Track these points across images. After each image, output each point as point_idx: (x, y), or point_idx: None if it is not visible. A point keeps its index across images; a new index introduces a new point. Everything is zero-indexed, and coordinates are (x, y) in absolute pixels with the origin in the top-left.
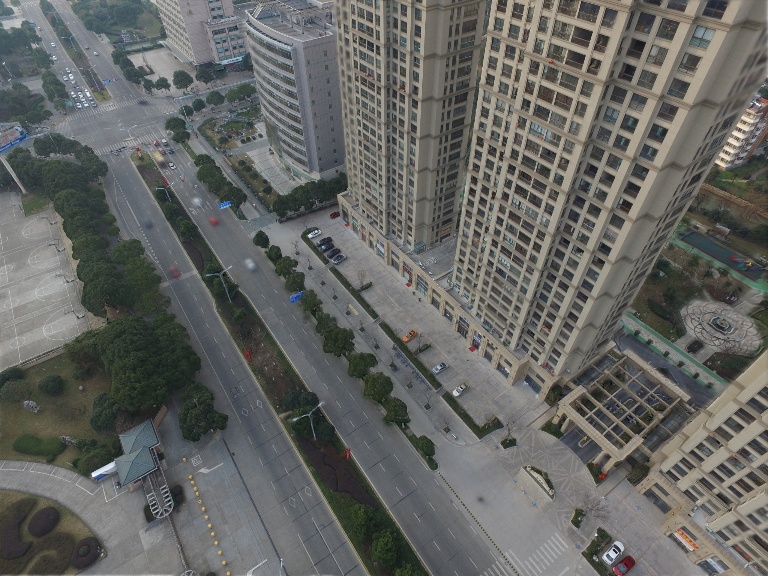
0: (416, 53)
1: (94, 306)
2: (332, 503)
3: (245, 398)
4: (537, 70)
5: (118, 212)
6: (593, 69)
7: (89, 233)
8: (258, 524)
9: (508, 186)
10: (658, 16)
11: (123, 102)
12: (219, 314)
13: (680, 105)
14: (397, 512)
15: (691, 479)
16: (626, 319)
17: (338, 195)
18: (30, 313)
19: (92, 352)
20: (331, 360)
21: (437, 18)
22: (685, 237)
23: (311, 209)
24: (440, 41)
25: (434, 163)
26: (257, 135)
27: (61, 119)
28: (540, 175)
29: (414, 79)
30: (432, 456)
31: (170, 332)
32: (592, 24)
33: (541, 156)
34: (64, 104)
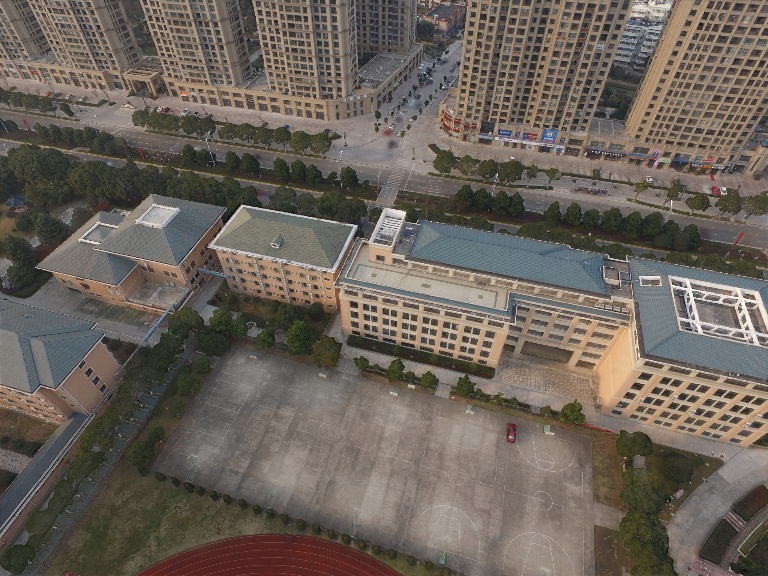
0: None
1: None
2: (28, 142)
3: None
4: None
5: None
6: None
7: None
8: None
9: None
10: None
11: None
12: None
13: None
14: None
15: None
16: None
17: None
18: None
19: None
20: (4, 115)
21: None
22: None
23: None
24: None
25: None
26: None
27: None
28: None
29: None
30: (74, 115)
31: None
32: None
33: None
34: None
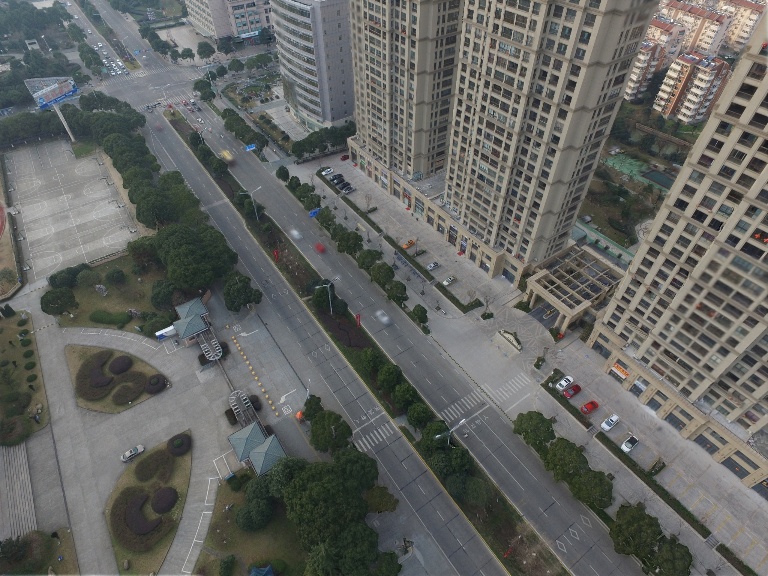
0: None
1: (147, 218)
2: (346, 354)
3: (274, 287)
4: None
5: (156, 156)
6: None
7: (137, 166)
8: (288, 368)
9: (485, 99)
10: None
11: (152, 70)
12: (249, 230)
13: (597, 13)
14: (397, 360)
15: (623, 321)
16: (589, 232)
17: (348, 138)
18: (90, 229)
19: (150, 249)
20: (343, 262)
21: None
22: (645, 174)
23: (324, 153)
24: None
25: (429, 97)
26: (274, 97)
27: (98, 84)
28: (507, 85)
29: (413, 22)
30: (425, 323)
31: (212, 235)
32: None
33: (508, 69)
34: (100, 70)
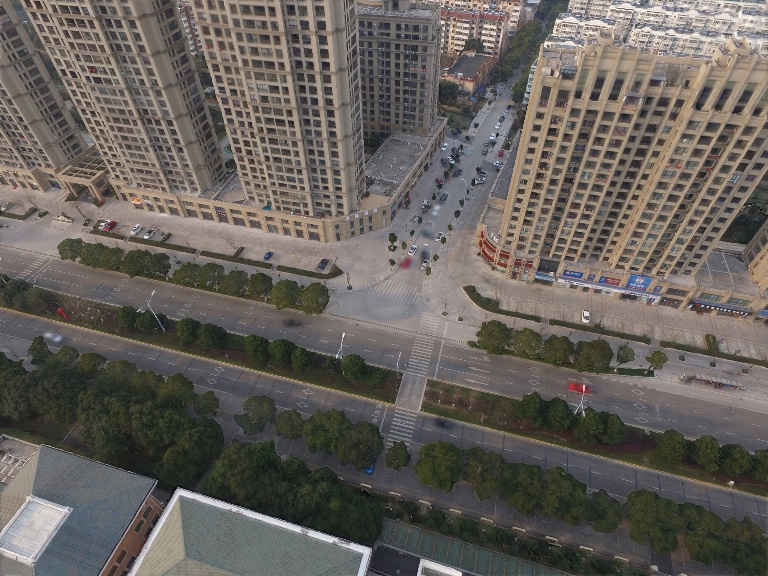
0: None
1: None
2: None
3: None
4: None
5: None
6: None
7: None
8: None
9: None
10: None
11: None
12: None
13: None
14: None
15: None
16: None
17: None
18: None
19: None
20: None
21: None
22: None
23: None
24: None
25: None
26: None
27: None
28: None
29: None
30: None
31: None
32: None
33: None
34: None
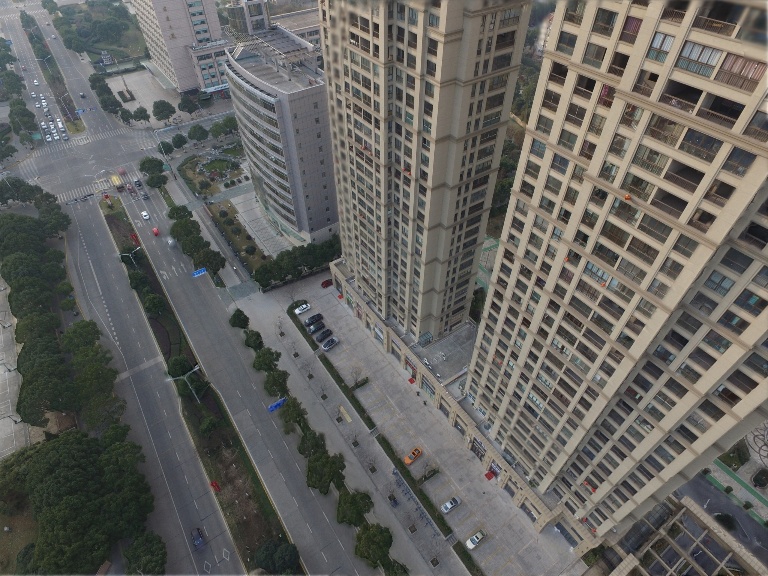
0: (425, 134)
1: (30, 417)
2: None
3: (209, 545)
4: (603, 201)
5: (78, 275)
6: (699, 223)
7: (36, 312)
8: None
9: (547, 323)
10: None
11: (98, 134)
12: (185, 419)
13: None
14: None
15: None
16: None
17: (330, 263)
18: None
19: (19, 488)
20: None
21: (454, 95)
22: None
23: None
24: (457, 122)
25: (445, 254)
26: (243, 177)
27: (27, 155)
28: (596, 326)
29: (422, 162)
30: None
31: (118, 459)
32: (705, 163)
33: (600, 305)
34: (31, 138)
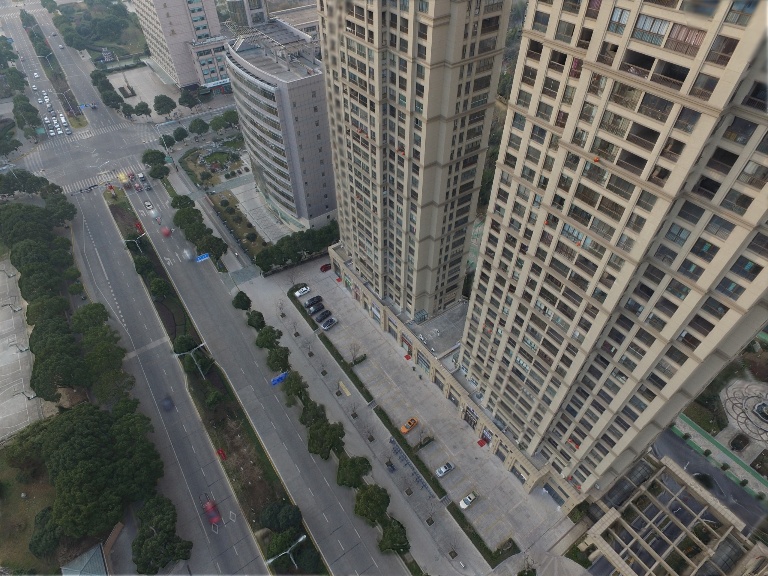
0: (417, 114)
1: (44, 391)
2: None
3: (216, 508)
4: (576, 165)
5: (85, 262)
6: (657, 178)
7: (46, 295)
8: None
9: (531, 286)
10: (762, 125)
11: (100, 129)
12: (191, 394)
13: None
14: None
15: None
16: None
17: (329, 248)
18: None
19: (35, 455)
20: (318, 456)
21: (443, 76)
22: None
23: None
24: (447, 102)
25: (438, 231)
26: (243, 169)
27: (31, 148)
28: (574, 284)
29: (415, 142)
30: None
31: (129, 429)
32: (660, 123)
33: (576, 264)
34: (35, 132)
